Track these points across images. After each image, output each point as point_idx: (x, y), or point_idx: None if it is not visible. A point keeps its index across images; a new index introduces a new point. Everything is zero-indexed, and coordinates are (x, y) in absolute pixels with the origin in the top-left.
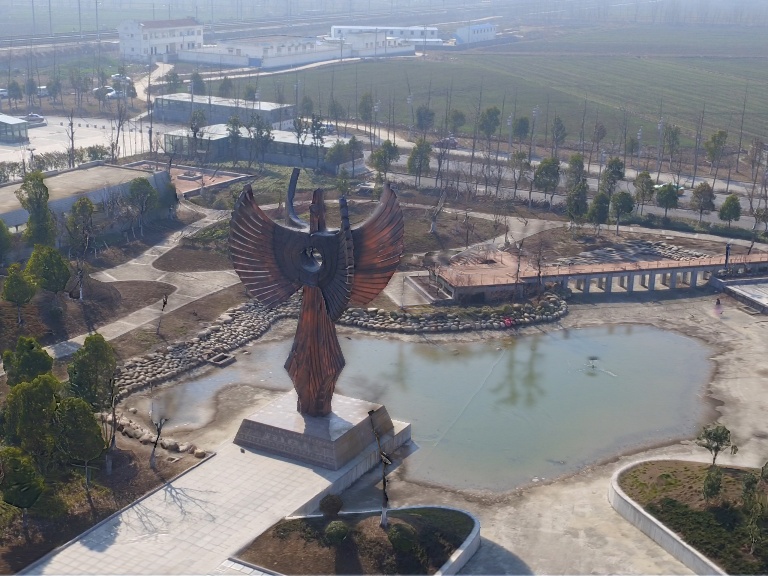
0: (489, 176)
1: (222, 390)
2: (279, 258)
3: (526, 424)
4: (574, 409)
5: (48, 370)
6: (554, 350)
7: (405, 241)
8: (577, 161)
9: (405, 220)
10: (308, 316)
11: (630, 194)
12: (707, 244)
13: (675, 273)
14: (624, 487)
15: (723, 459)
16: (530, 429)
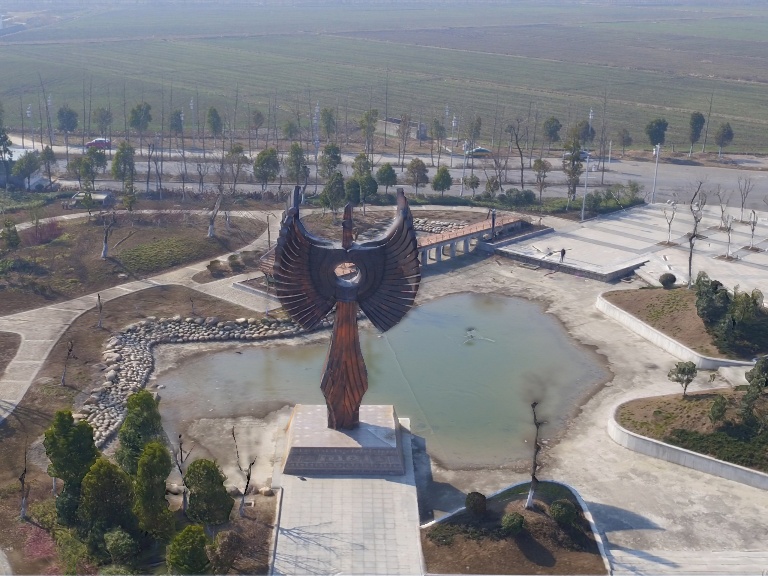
0: (204, 173)
1: (185, 428)
2: (315, 278)
3: (478, 397)
4: (497, 376)
5: (93, 442)
6: (424, 329)
7: (193, 248)
8: (298, 150)
9: (171, 227)
10: (342, 332)
11: (348, 176)
12: (442, 214)
13: (454, 243)
14: (630, 429)
15: (650, 391)
16: (485, 401)
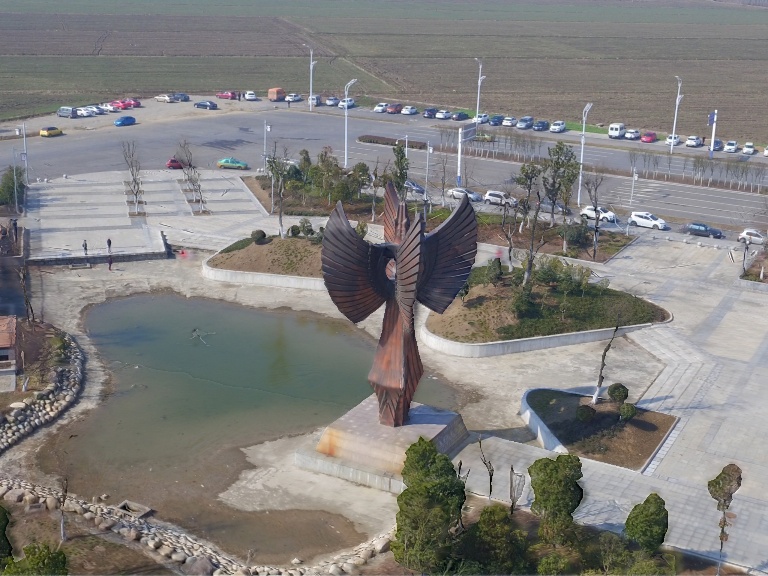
0: None
1: (232, 509)
2: None
3: (321, 374)
4: (287, 355)
5: None
6: (146, 346)
7: None
8: None
9: None
10: None
11: None
12: None
13: None
14: (472, 342)
15: None
16: (328, 375)
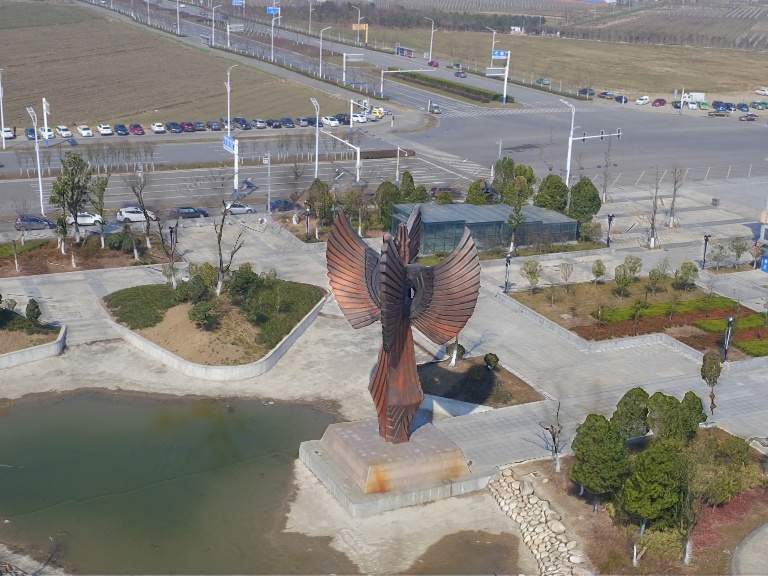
0: None
1: (397, 575)
2: None
3: (179, 443)
4: (109, 442)
5: None
6: None
7: None
8: None
9: None
10: None
11: None
12: None
13: None
14: (255, 360)
15: (127, 371)
16: (183, 441)
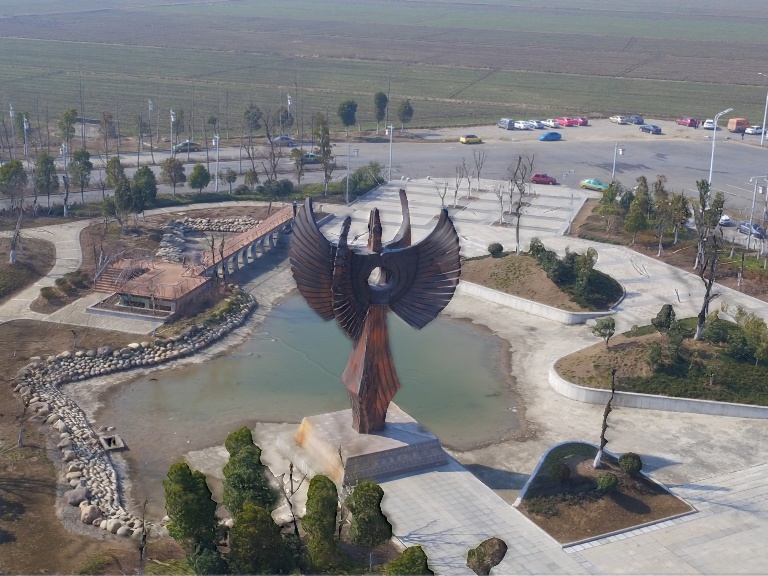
0: None
1: None
2: (355, 286)
3: (417, 382)
4: (412, 360)
5: None
6: (305, 326)
7: (4, 278)
8: (48, 159)
9: None
10: (374, 335)
11: None
12: (217, 211)
13: (264, 239)
14: (583, 385)
15: (551, 350)
16: (425, 384)
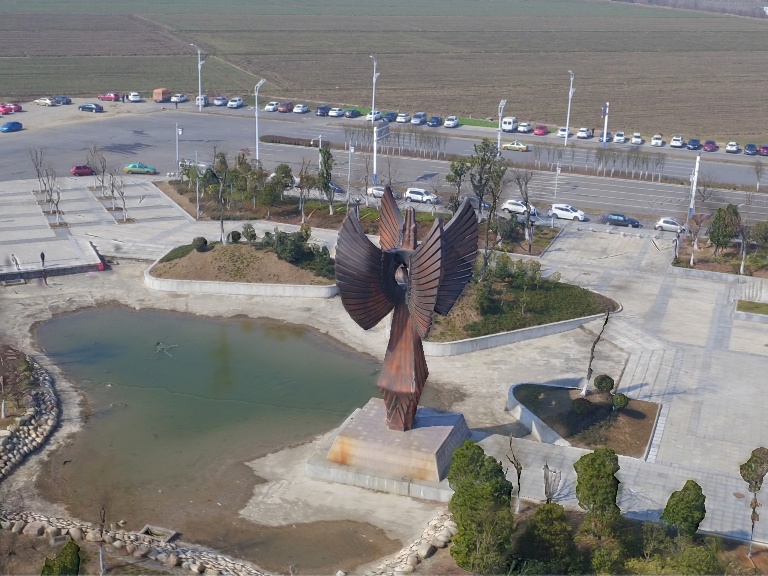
0: None
1: (258, 526)
2: None
3: (299, 382)
4: (259, 364)
5: None
6: (111, 363)
7: None
8: None
9: None
10: None
11: None
12: None
13: None
14: (442, 341)
15: None
16: (306, 382)
